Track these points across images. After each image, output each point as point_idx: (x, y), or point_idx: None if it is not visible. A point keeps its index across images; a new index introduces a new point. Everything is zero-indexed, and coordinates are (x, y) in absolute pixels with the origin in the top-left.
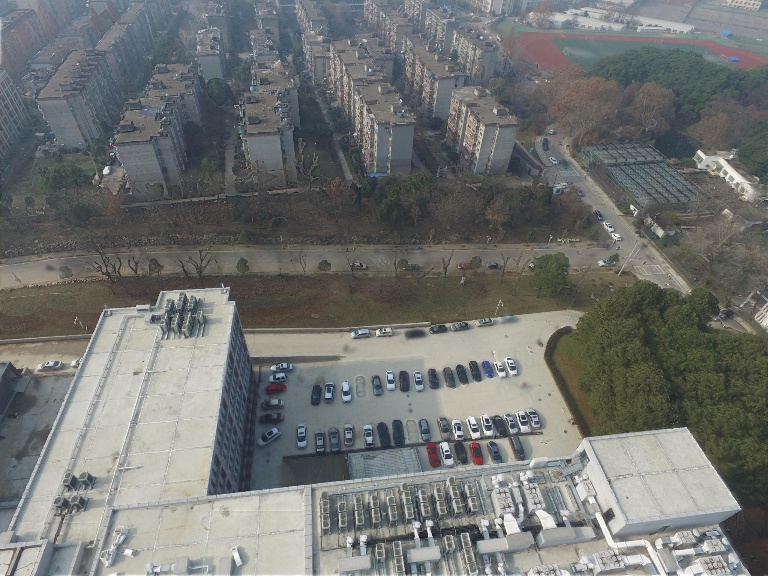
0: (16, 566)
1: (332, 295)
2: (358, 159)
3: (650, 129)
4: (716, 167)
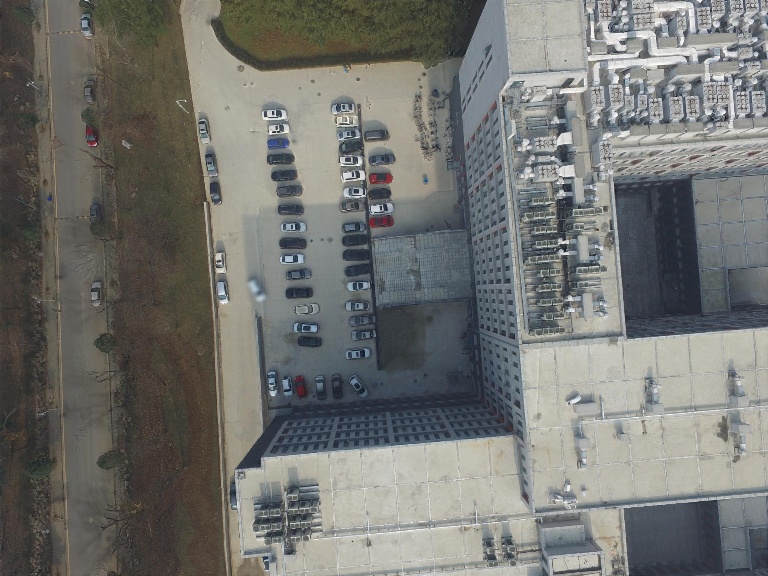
0: (566, 571)
1: (164, 330)
2: None
3: None
4: None
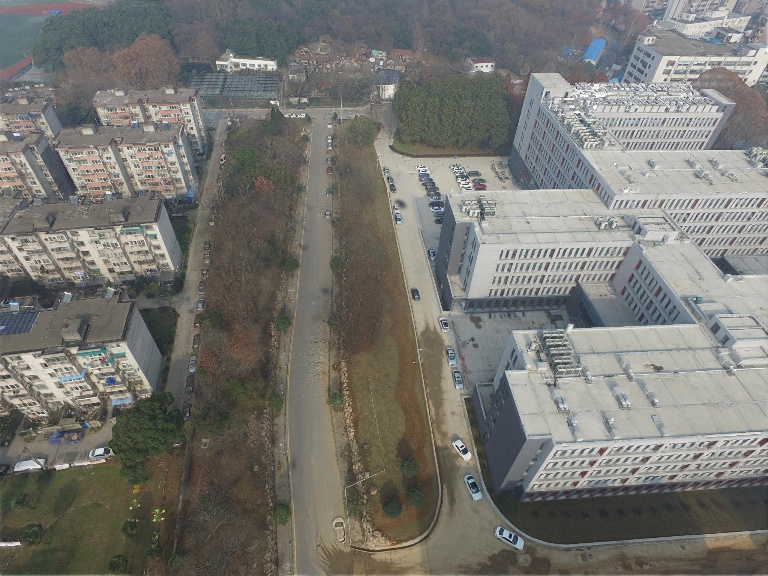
0: None
1: None
2: None
3: None
4: (234, 66)
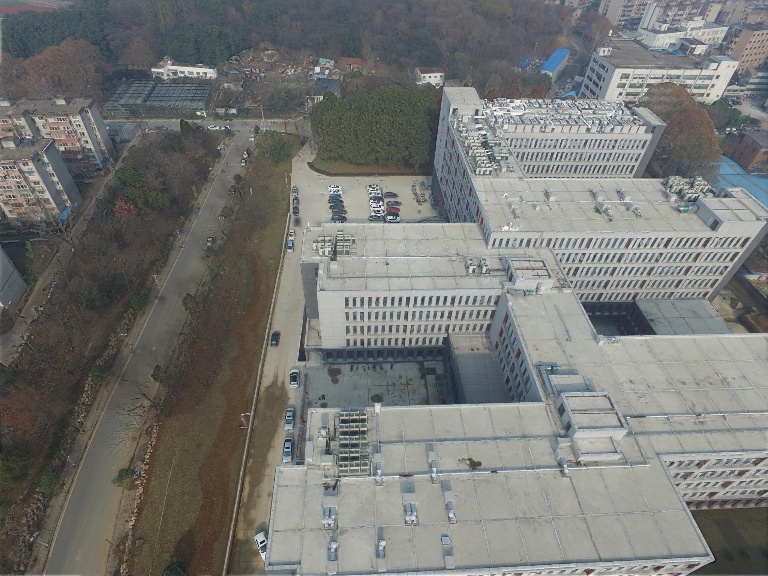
0: None
1: None
2: (10, 227)
3: (105, 74)
4: (171, 73)
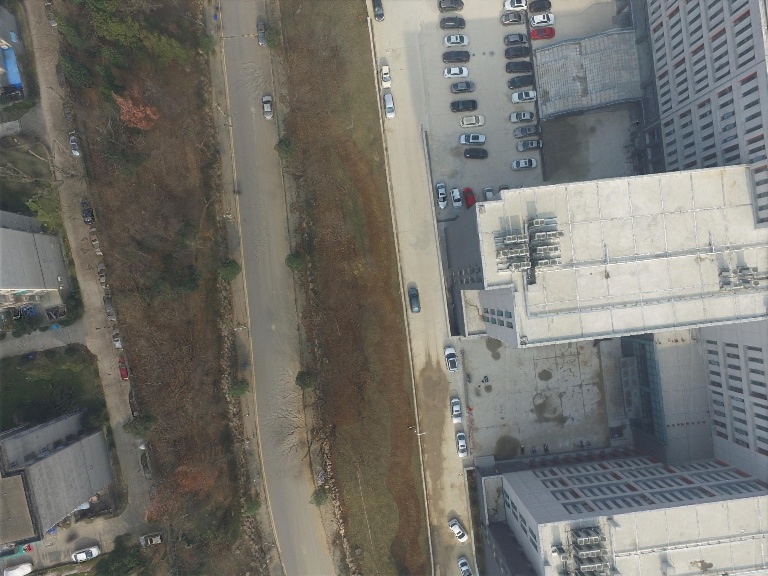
0: None
1: (341, 136)
2: None
3: None
4: None
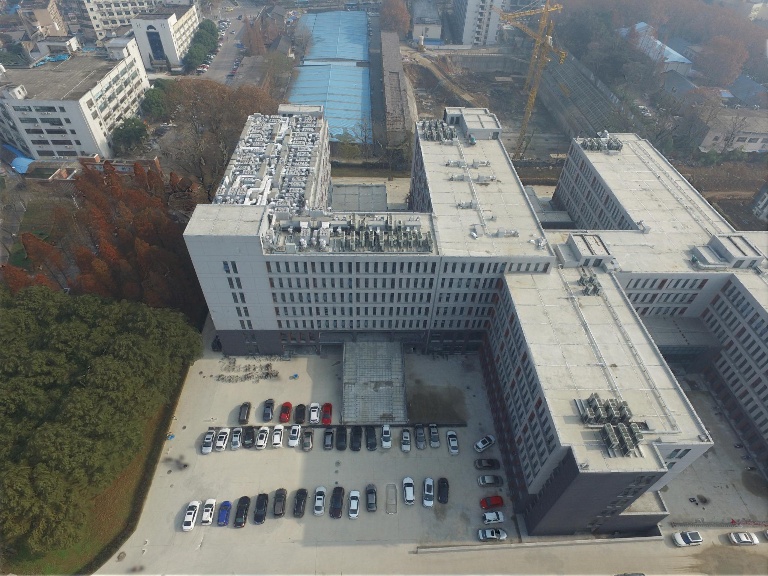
0: None
1: None
2: None
3: None
4: None
